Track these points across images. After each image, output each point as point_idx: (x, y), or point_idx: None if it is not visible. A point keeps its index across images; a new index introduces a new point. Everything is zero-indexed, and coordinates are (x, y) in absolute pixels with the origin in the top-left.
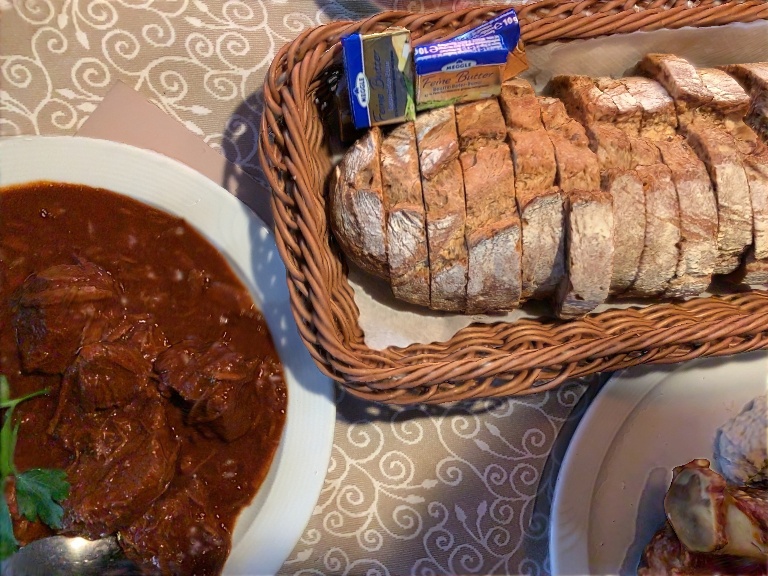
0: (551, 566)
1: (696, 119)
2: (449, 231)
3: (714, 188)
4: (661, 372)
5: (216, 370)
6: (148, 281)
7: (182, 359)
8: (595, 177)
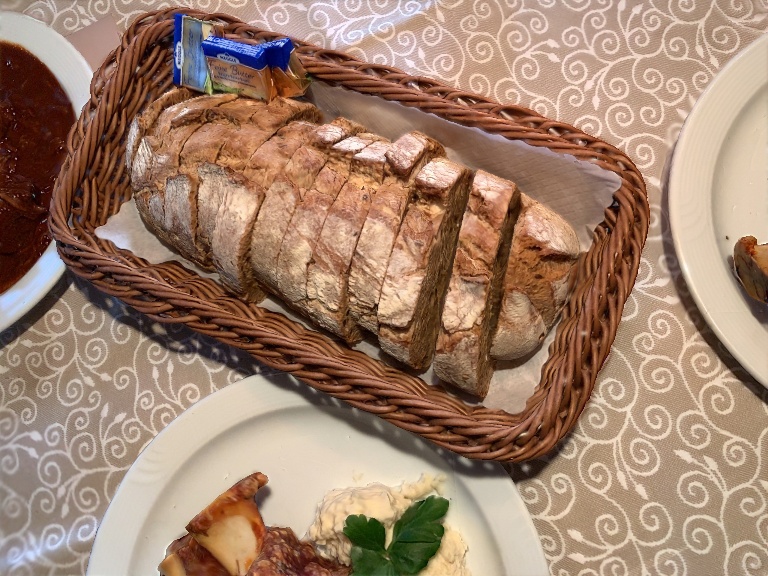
0: (119, 486)
1: (395, 184)
2: (163, 167)
3: (359, 235)
4: (303, 398)
5: (6, 192)
6: (31, 131)
7: (2, 179)
8: (271, 177)
